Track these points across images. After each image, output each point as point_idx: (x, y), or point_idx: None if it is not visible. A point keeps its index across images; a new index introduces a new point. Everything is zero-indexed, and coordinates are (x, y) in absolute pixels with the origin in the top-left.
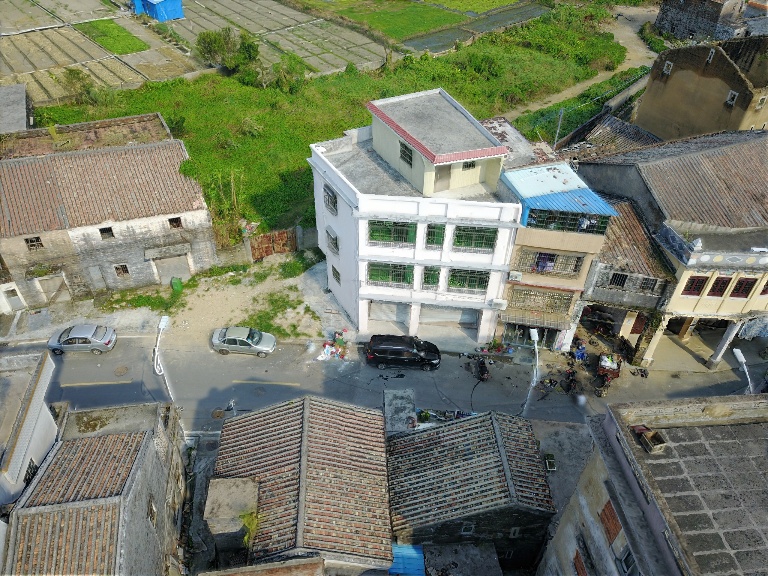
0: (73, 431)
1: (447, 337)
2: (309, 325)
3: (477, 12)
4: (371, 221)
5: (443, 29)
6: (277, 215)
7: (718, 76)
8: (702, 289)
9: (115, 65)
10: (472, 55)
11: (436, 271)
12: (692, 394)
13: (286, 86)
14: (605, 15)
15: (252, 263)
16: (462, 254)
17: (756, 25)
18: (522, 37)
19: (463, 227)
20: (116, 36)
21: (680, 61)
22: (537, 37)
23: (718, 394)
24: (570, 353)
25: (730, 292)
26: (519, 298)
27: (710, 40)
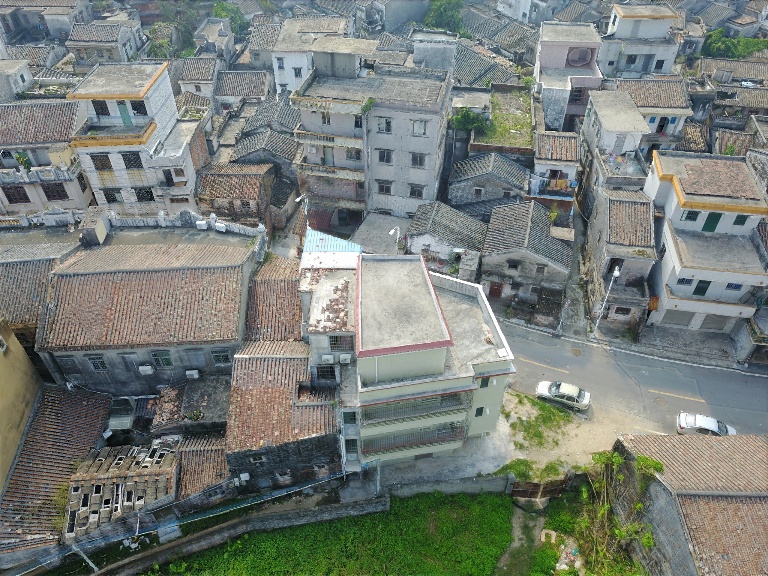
0: (649, 252)
1: None
2: (507, 400)
3: None
4: None
5: None
6: (534, 574)
7: None
8: None
9: None
10: None
11: None
12: None
13: None
14: None
15: None
16: None
17: None
18: None
19: None
20: None
21: None
22: None
23: None
24: None
25: None
26: None
27: None
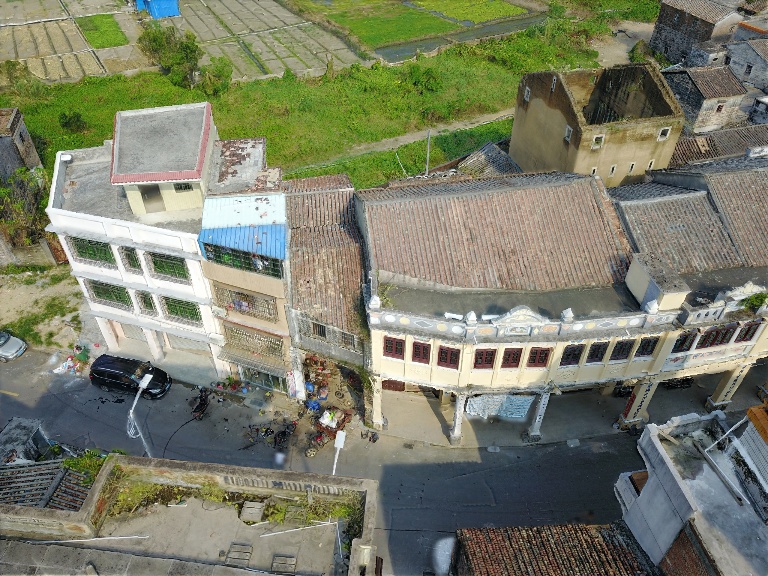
0: None
1: (192, 366)
2: (66, 335)
3: (474, 21)
4: (69, 237)
5: (426, 38)
6: None
7: (559, 107)
8: (404, 353)
9: (86, 58)
10: (412, 67)
11: (147, 296)
12: (413, 470)
13: (210, 88)
14: (600, 31)
15: (55, 265)
16: (165, 281)
17: (736, 50)
18: (494, 50)
19: (152, 253)
20: (104, 30)
21: (534, 87)
22: (510, 51)
23: (442, 474)
24: (304, 402)
25: (435, 361)
26: (234, 336)
27: (685, 64)
